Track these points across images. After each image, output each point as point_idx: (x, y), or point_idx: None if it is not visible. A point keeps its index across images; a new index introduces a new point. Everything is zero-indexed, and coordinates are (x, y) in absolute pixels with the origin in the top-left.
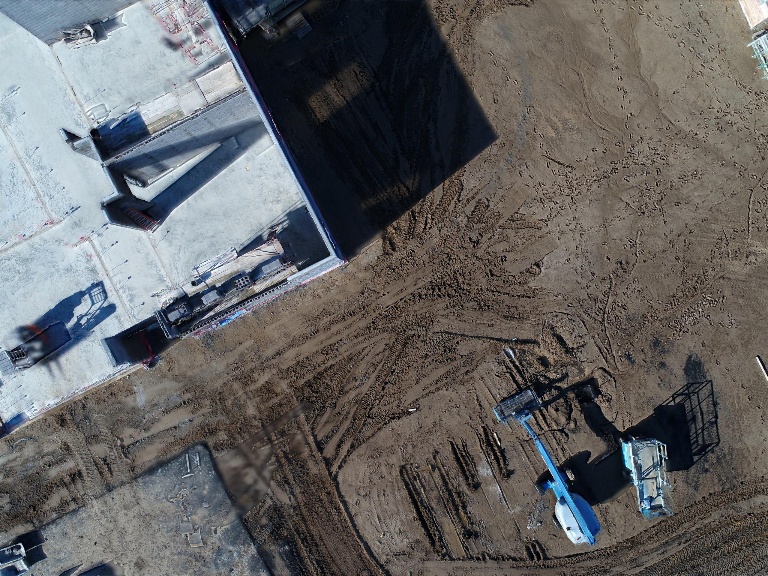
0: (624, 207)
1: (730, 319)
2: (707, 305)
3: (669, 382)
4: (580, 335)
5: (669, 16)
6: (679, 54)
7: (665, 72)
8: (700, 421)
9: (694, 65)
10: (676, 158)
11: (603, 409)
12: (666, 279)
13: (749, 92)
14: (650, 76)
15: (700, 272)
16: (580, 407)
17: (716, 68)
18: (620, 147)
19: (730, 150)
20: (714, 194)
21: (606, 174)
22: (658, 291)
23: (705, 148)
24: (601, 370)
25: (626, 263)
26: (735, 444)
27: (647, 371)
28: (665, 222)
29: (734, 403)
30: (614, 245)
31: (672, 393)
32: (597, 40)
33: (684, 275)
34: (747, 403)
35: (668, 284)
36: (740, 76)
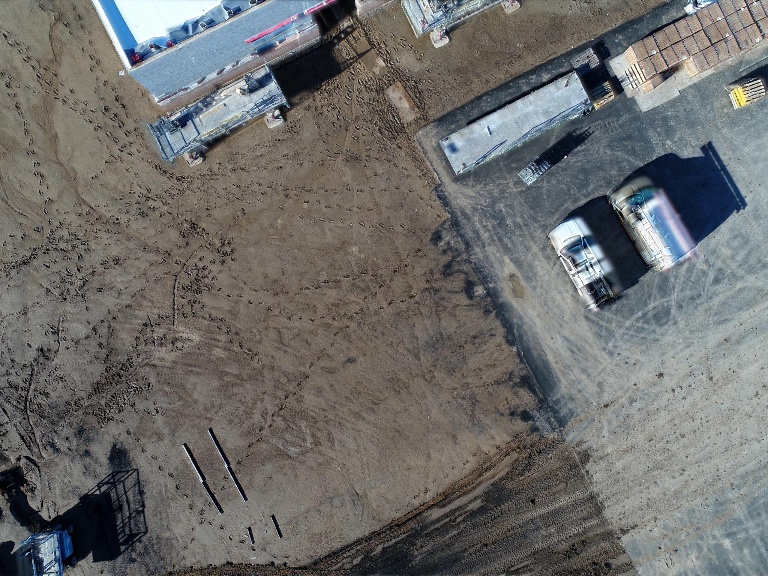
0: (44, 293)
1: (156, 407)
2: (132, 392)
3: (94, 471)
4: (1, 423)
5: (84, 100)
6: (96, 138)
7: (82, 157)
8: (127, 510)
9: (112, 150)
10: (97, 243)
11: (28, 498)
12: (89, 366)
13: (170, 177)
14: (68, 160)
15: (125, 359)
16: (8, 496)
17: (135, 153)
18: (39, 232)
19: (153, 235)
20: (137, 280)
21: (25, 260)
22: (81, 378)
23: (127, 233)
24: (24, 459)
25: (48, 350)
26: (163, 533)
27: (72, 459)
28: (87, 308)
29: (161, 492)
30: (35, 332)
31: (97, 482)
32: (11, 124)
33: (108, 362)
34: (175, 492)
35: (92, 371)
36: (160, 161)
